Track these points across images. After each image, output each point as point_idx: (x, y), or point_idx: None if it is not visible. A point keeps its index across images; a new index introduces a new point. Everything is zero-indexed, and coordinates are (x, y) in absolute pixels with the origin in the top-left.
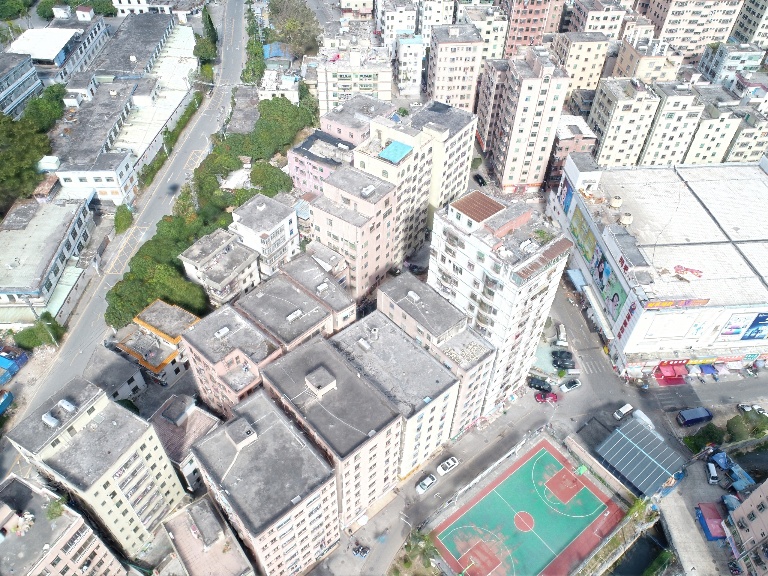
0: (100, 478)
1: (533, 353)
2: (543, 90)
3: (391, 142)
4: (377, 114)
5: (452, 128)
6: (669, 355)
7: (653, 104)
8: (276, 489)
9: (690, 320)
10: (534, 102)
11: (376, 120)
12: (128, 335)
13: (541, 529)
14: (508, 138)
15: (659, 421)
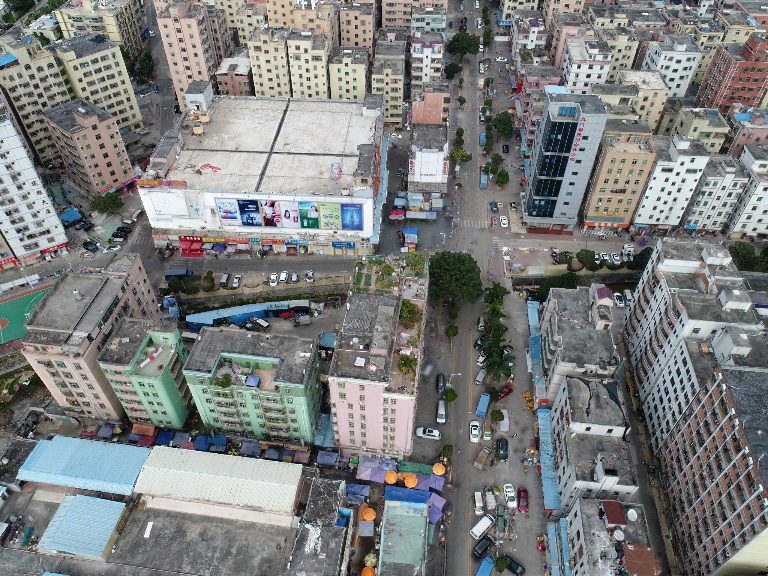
0: None
1: (51, 211)
2: (178, 29)
3: (7, 55)
4: None
5: (91, 53)
6: (188, 232)
7: (279, 47)
8: None
9: (181, 200)
10: (175, 39)
11: (2, 38)
12: None
13: (7, 330)
14: None
15: (156, 278)
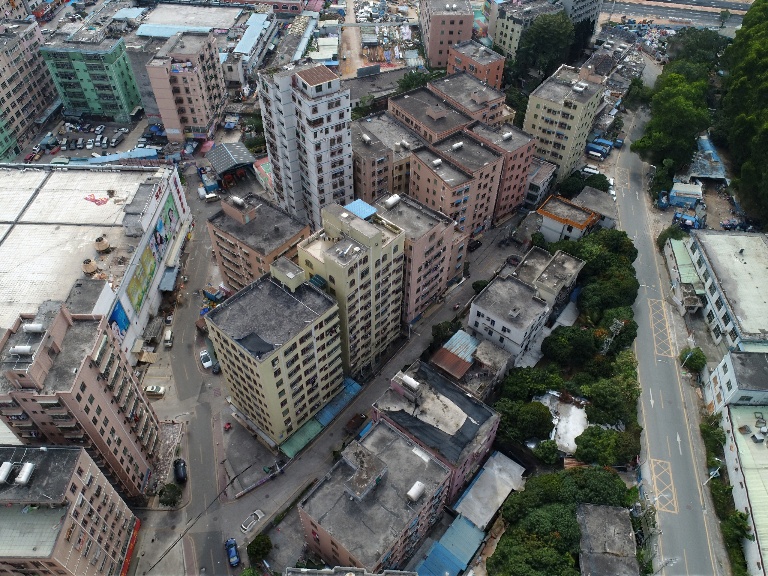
0: None
1: None
2: None
3: None
4: (346, 450)
5: (255, 300)
6: None
7: None
8: (457, 84)
9: None
10: None
11: (374, 231)
12: None
13: None
14: (137, 394)
15: (190, 195)
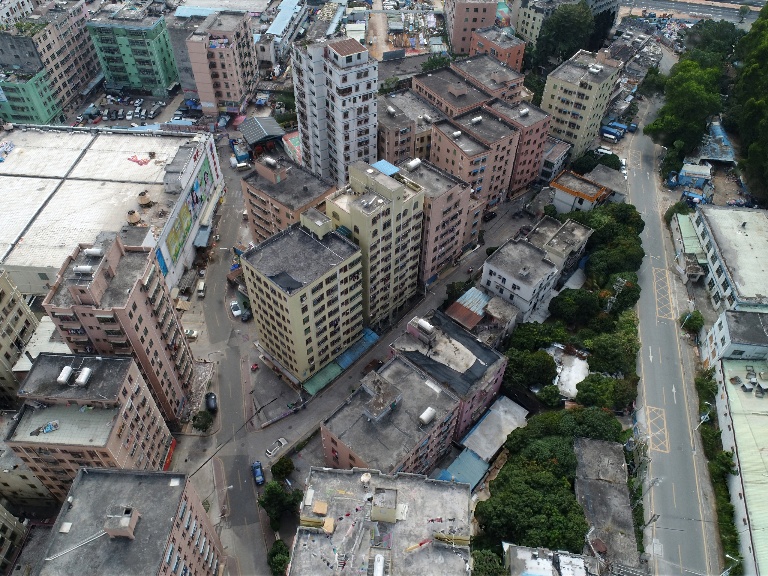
0: (563, 63)
1: None
2: None
3: None
4: (365, 379)
5: (286, 245)
6: None
7: None
8: None
9: None
10: None
11: (397, 185)
12: (606, 194)
13: None
14: None
15: (223, 164)
